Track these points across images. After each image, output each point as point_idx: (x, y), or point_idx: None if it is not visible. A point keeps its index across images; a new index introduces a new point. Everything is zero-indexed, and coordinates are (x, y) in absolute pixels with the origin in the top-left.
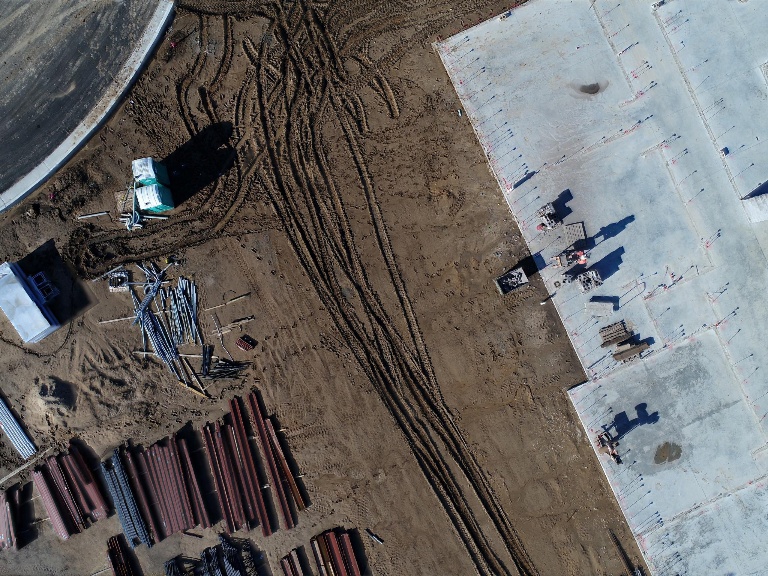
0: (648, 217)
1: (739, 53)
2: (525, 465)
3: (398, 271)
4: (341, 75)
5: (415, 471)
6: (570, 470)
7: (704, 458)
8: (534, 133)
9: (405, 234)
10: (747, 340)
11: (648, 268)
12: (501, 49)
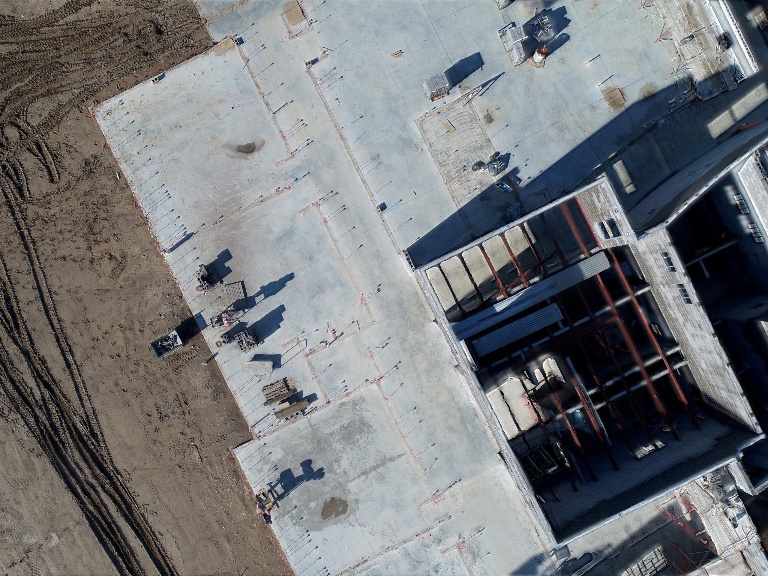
0: (308, 274)
1: (394, 108)
2: (195, 524)
3: (64, 335)
4: (1, 141)
5: (87, 533)
6: (240, 528)
7: (370, 512)
8: (191, 194)
9: (69, 298)
10: (410, 393)
11: (309, 325)
12: (156, 111)
